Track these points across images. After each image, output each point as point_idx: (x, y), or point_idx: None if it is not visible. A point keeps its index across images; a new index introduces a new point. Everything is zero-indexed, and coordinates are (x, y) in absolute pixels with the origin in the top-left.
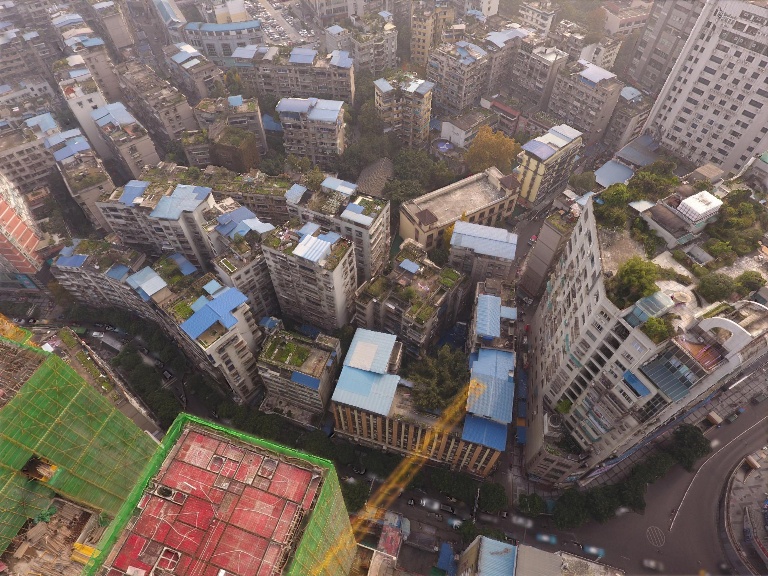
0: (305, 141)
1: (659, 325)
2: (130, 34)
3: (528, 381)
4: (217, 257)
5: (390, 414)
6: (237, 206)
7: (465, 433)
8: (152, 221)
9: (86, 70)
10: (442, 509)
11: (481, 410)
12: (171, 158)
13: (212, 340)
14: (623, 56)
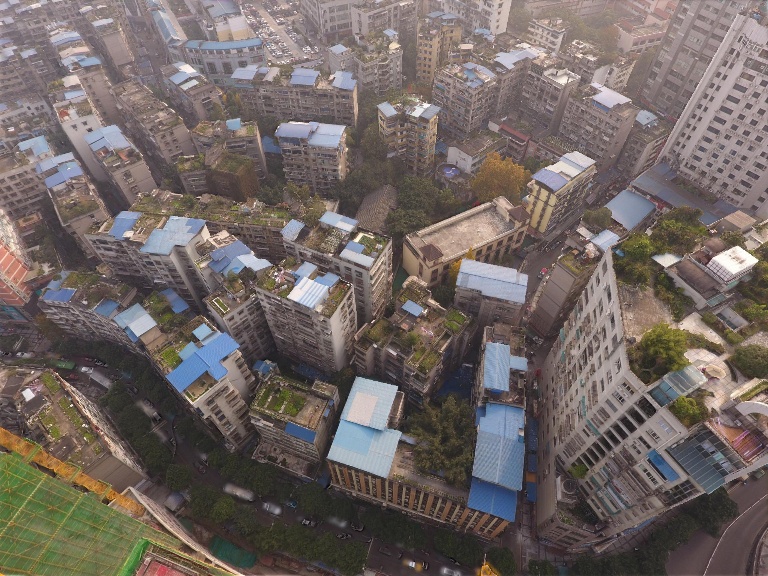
0: (305, 166)
1: (691, 406)
2: (130, 51)
3: (539, 432)
4: (209, 296)
5: (390, 475)
6: (232, 240)
7: (471, 500)
8: (143, 255)
9: (82, 91)
10: (446, 573)
11: (489, 475)
12: (167, 184)
13: (200, 392)
14: (636, 76)
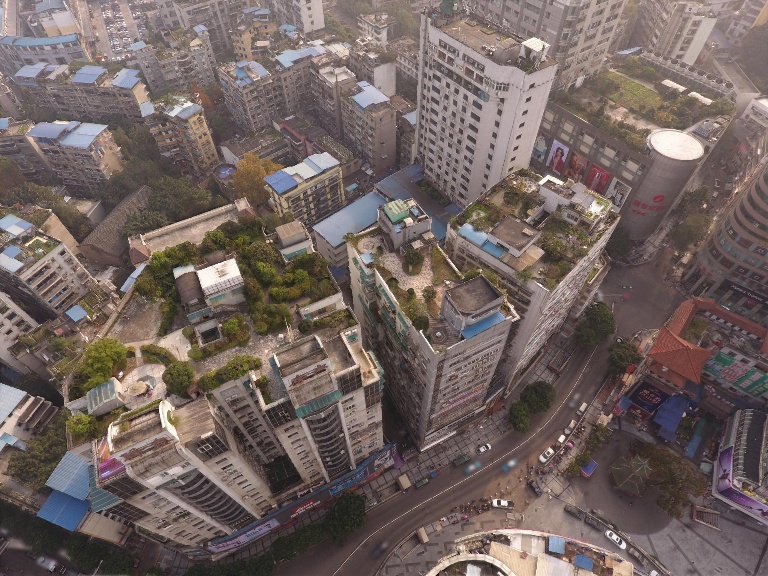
0: (70, 166)
1: (77, 425)
2: None
3: None
4: None
5: None
6: None
7: (43, 508)
8: None
9: None
10: None
11: (59, 484)
12: None
13: None
14: None
